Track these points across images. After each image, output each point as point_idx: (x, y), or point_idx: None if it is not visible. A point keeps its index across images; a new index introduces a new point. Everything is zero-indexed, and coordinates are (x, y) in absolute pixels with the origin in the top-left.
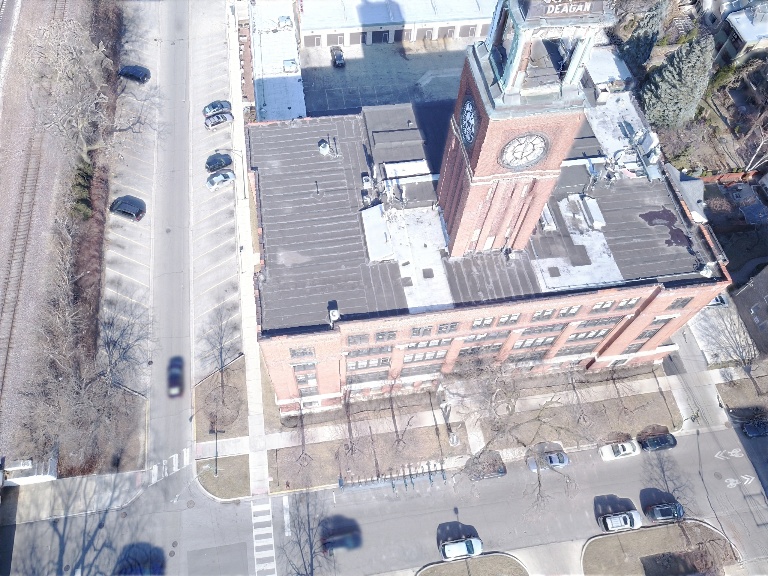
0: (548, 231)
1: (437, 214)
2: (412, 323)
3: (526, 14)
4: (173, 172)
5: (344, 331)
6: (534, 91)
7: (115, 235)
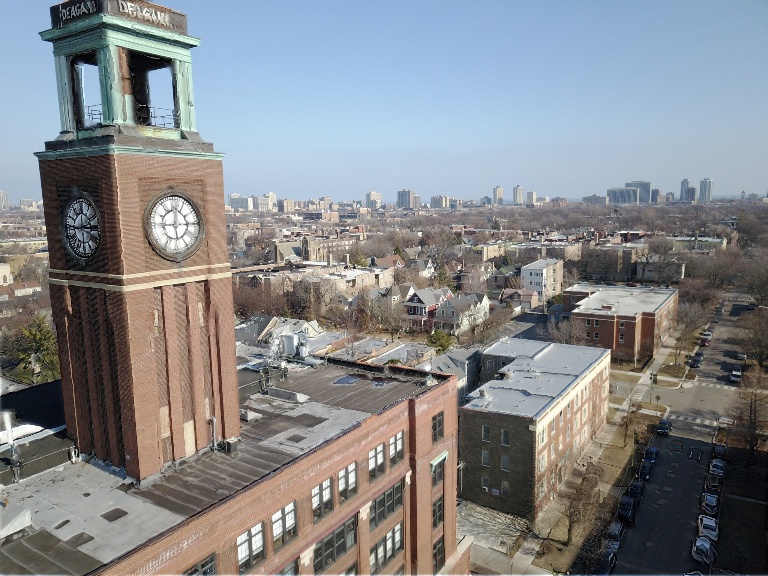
0: (255, 420)
1: (84, 464)
2: None
3: (107, 7)
4: None
5: None
6: None
7: None
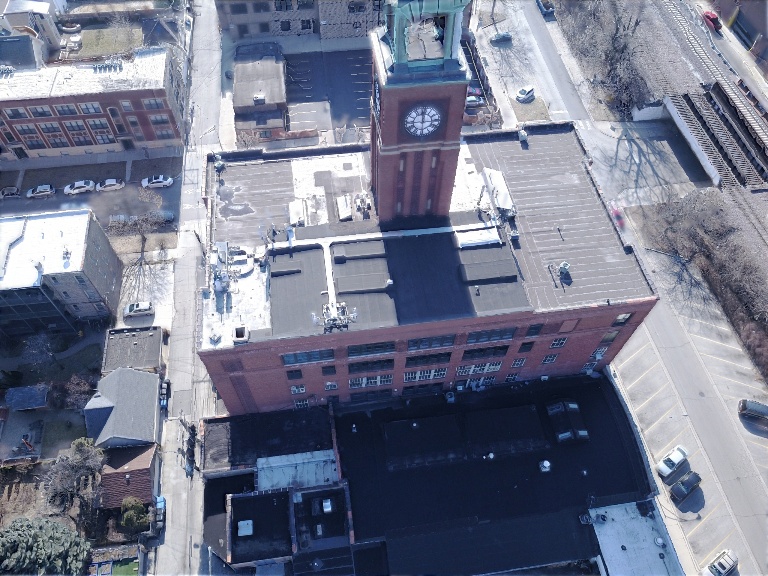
0: None
1: None
2: None
3: None
4: (738, 477)
5: None
6: None
7: (755, 386)
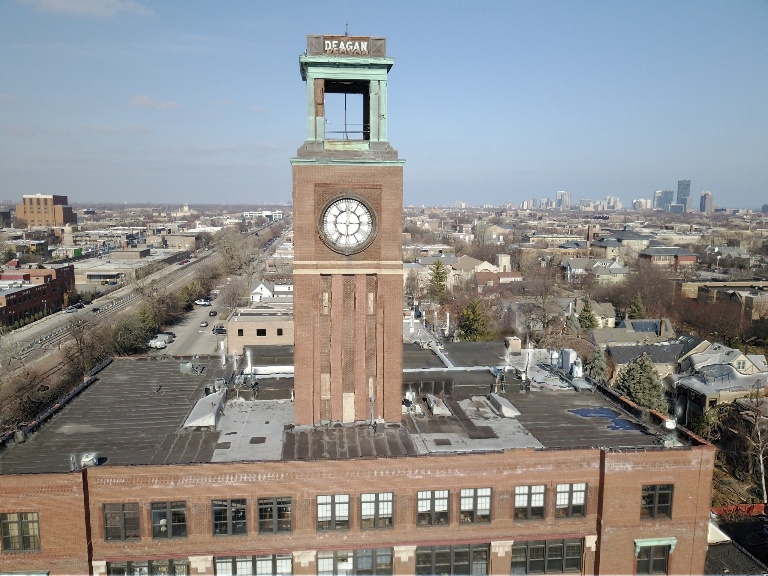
0: (440, 416)
1: None
2: (208, 482)
3: None
4: None
5: (95, 485)
6: (342, 149)
7: None
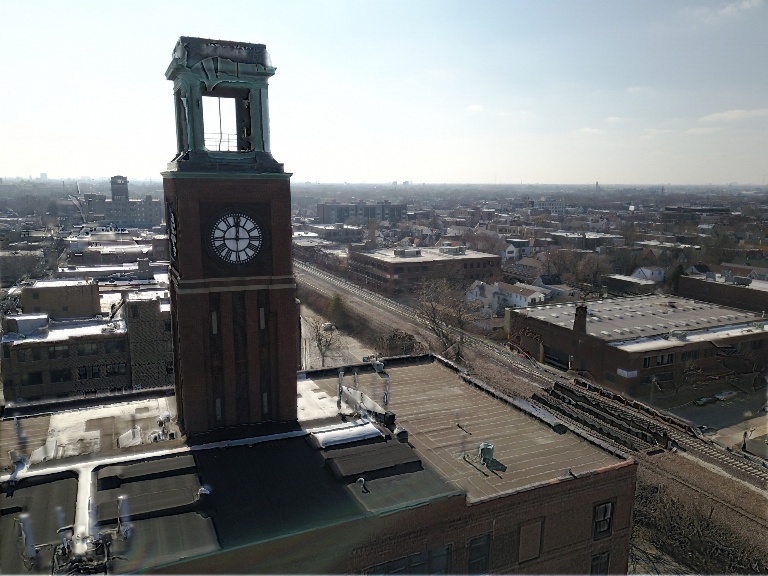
0: None
1: None
2: None
3: None
4: None
5: None
6: None
7: None
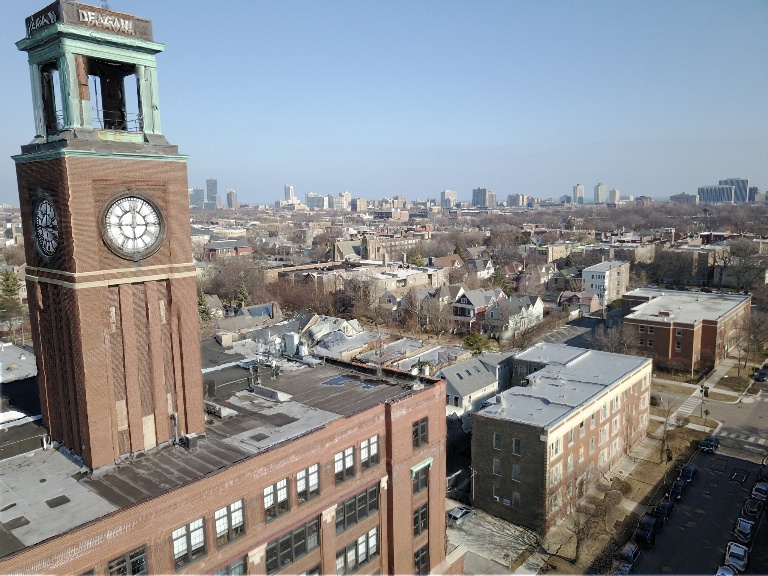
0: (229, 417)
1: (54, 451)
2: (43, 567)
3: (62, 18)
4: None
5: None
6: (114, 140)
7: None
